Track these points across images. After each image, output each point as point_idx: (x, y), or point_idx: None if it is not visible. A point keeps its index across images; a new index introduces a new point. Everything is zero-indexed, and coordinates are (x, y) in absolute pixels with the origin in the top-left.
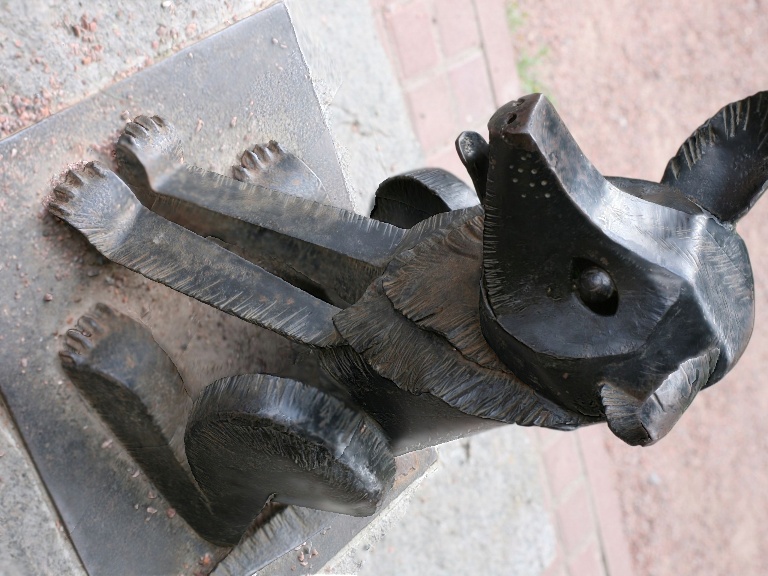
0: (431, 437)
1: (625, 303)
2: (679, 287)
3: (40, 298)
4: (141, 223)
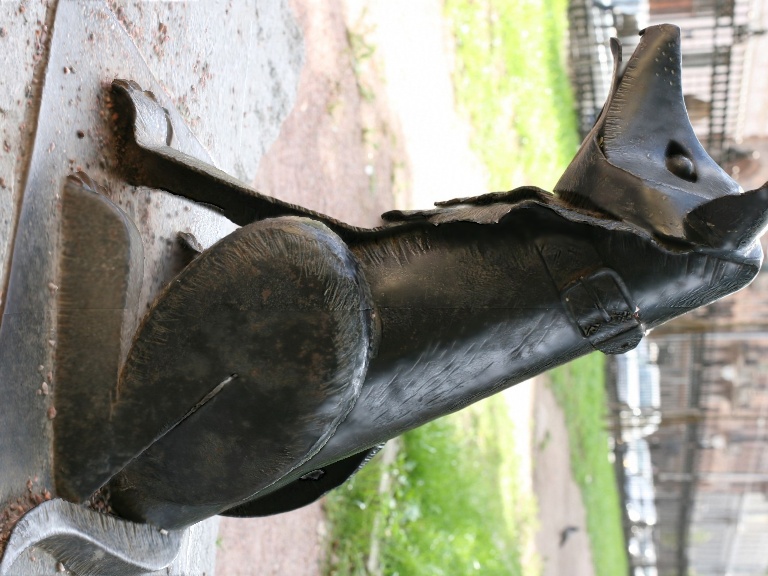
0: (422, 357)
1: (702, 180)
2: (737, 186)
3: (76, 127)
4: (169, 149)
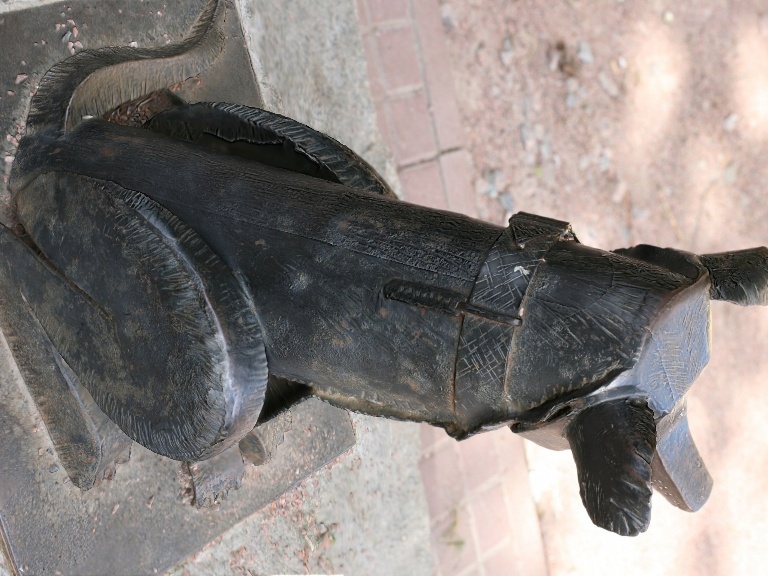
0: None
1: None
2: None
3: None
4: None
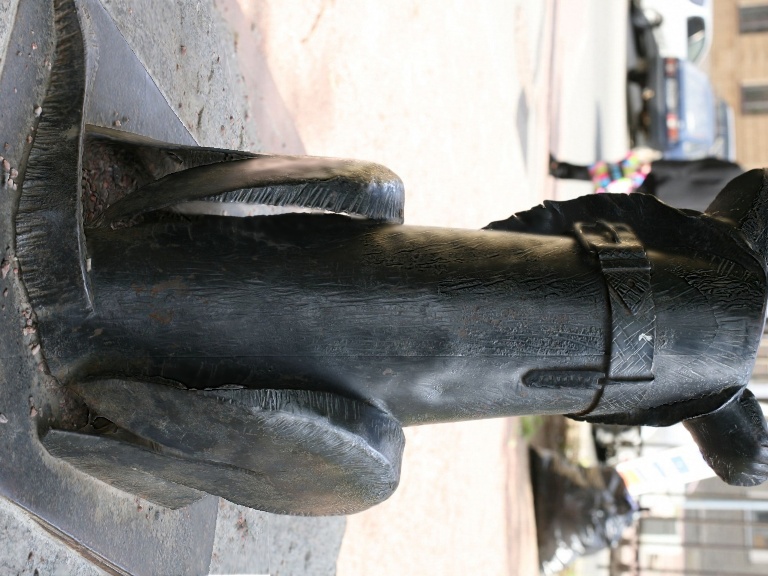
0: None
1: None
2: None
3: None
4: None
